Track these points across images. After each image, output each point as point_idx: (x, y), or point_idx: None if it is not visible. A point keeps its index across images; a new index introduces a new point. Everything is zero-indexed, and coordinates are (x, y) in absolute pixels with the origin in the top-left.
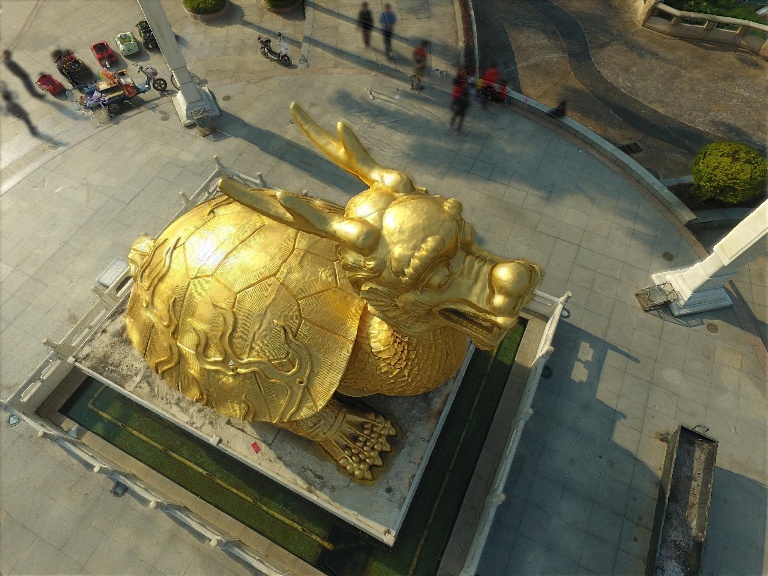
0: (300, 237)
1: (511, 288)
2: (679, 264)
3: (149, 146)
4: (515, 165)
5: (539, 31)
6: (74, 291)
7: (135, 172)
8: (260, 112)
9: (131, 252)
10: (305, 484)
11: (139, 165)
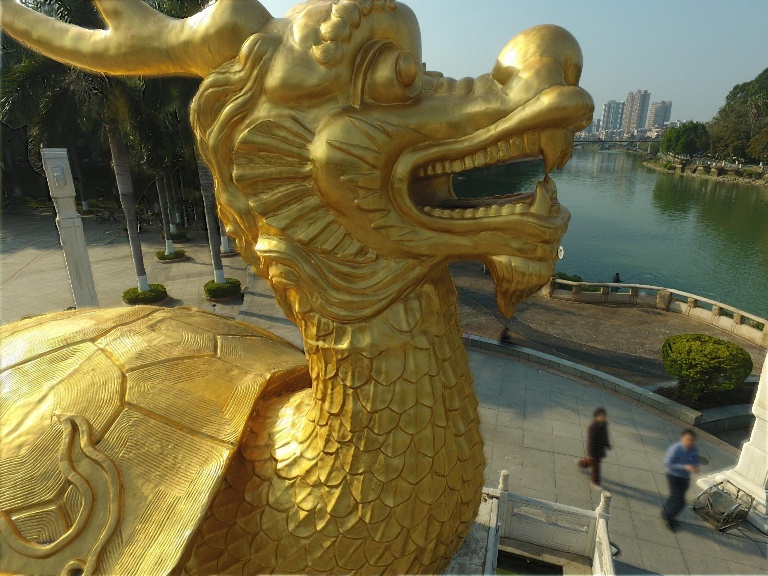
0: (164, 310)
1: (547, 35)
2: (719, 466)
3: None
4: (474, 387)
5: (463, 305)
6: None
7: None
8: None
9: None
10: None
11: None
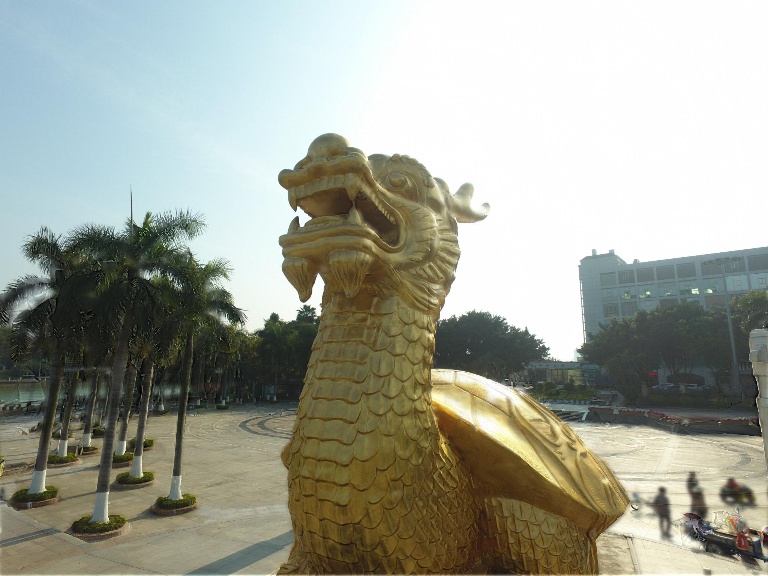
0: (474, 375)
1: None
2: None
3: (693, 573)
4: None
5: None
6: None
7: (646, 570)
8: None
9: None
10: None
11: (659, 571)
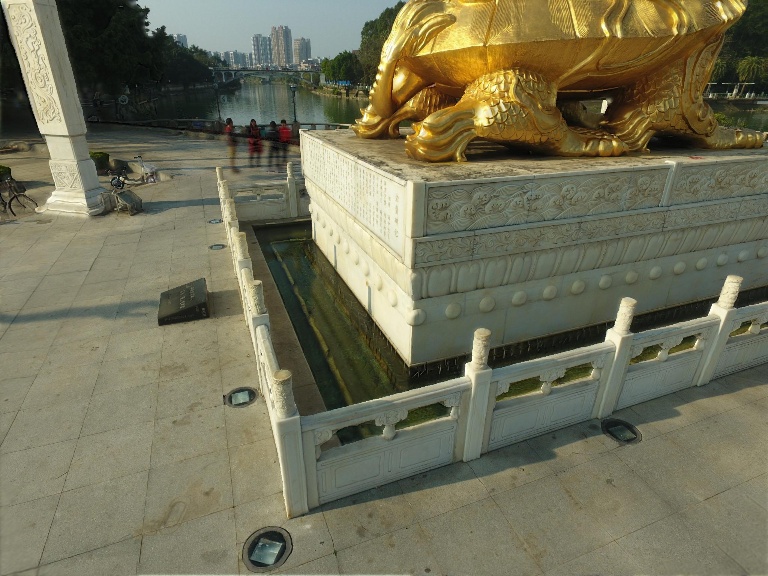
0: None
1: None
2: None
3: (50, 237)
4: None
5: None
6: (119, 351)
7: (58, 253)
8: (180, 195)
9: (417, 4)
10: (761, 155)
11: (56, 248)
